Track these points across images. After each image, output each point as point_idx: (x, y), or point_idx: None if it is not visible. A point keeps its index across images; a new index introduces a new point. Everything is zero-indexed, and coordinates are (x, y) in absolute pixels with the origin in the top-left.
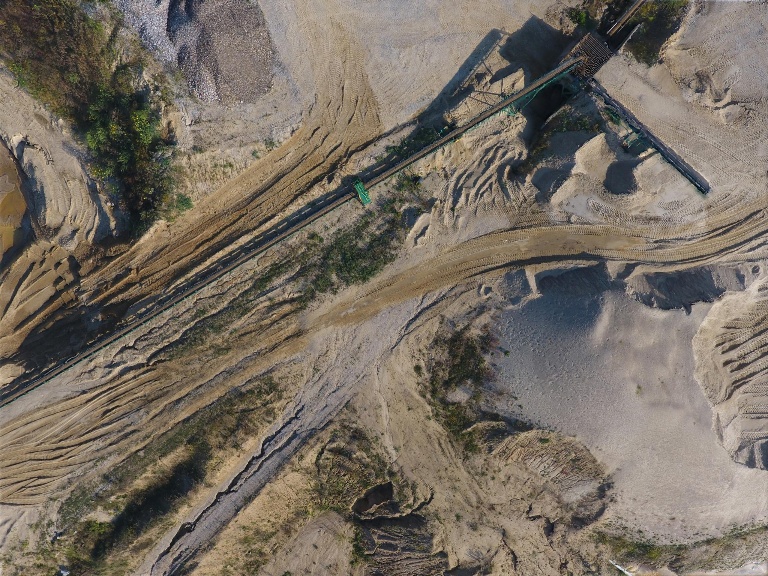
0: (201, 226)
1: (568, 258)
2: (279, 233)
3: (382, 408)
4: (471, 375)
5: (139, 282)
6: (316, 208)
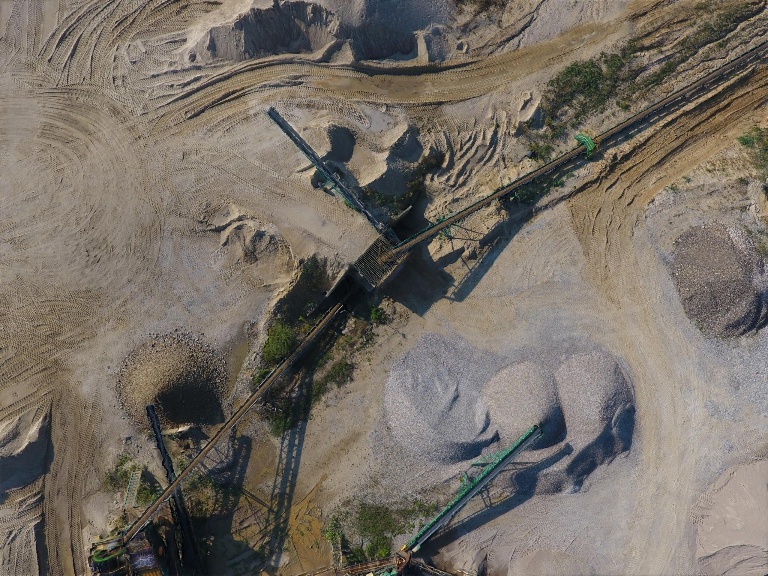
0: (726, 125)
1: (387, 71)
2: (657, 112)
3: None
4: None
5: None
6: (624, 134)
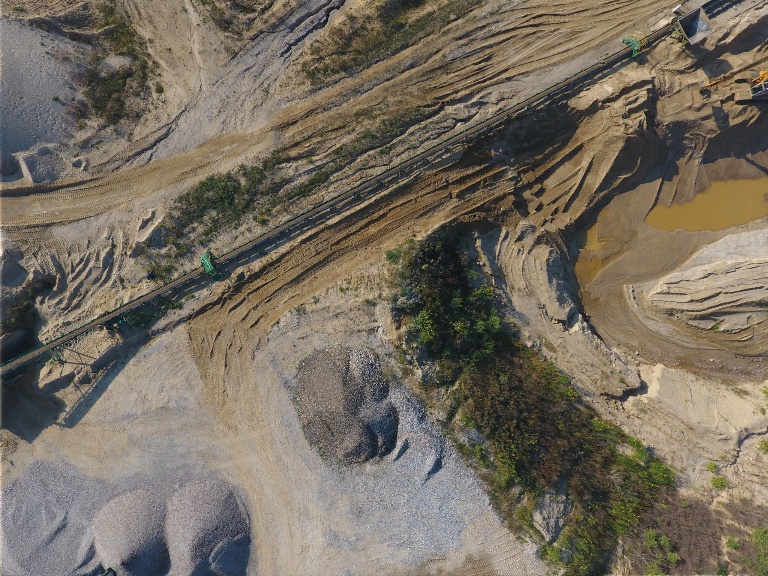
0: (381, 236)
1: None
2: (299, 226)
3: (198, 51)
4: (100, 80)
5: (449, 185)
6: (259, 250)
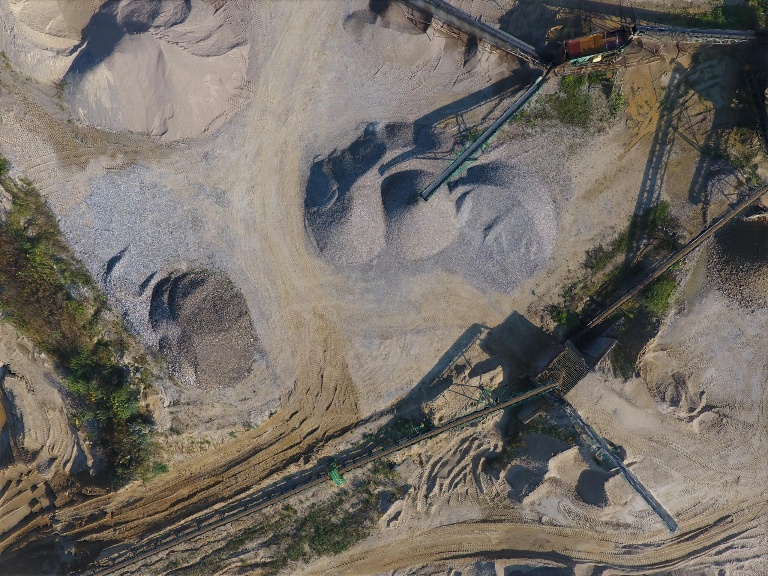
0: (177, 485)
1: (537, 556)
2: (254, 501)
3: None
4: None
5: (113, 527)
6: (291, 482)
